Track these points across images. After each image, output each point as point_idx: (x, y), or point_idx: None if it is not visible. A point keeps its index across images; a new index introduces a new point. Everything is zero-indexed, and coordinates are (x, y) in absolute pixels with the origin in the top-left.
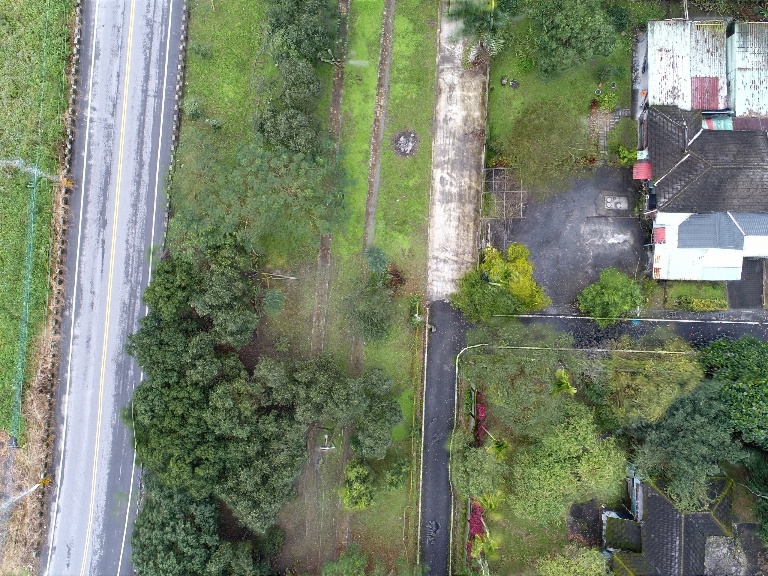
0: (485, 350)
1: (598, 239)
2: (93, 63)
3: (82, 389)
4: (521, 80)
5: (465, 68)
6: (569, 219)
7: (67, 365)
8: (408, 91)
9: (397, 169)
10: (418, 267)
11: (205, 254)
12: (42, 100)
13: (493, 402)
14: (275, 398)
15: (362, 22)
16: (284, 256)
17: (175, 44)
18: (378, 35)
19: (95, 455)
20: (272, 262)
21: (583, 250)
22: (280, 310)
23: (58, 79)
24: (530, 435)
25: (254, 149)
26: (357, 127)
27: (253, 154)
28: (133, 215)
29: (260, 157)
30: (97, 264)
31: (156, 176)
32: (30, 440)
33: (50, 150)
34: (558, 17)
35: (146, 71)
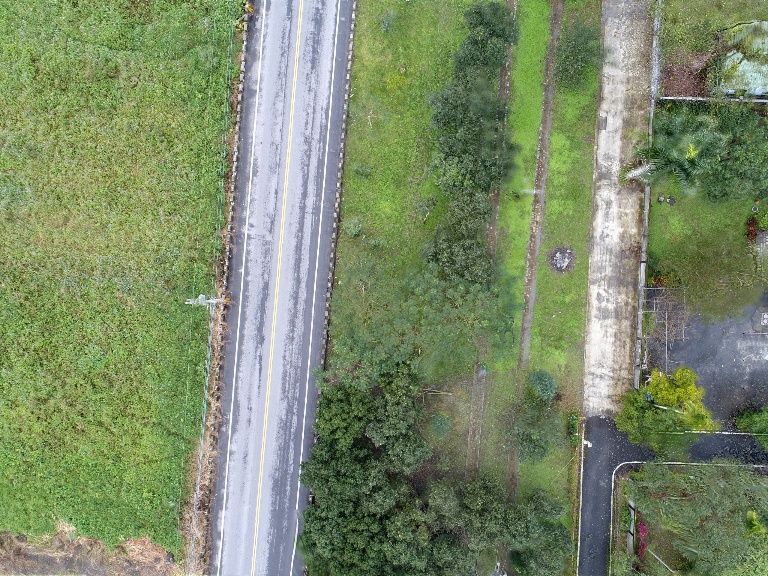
0: (644, 468)
1: (754, 355)
2: (251, 180)
3: (239, 505)
4: (678, 197)
5: (622, 185)
6: (725, 335)
7: (224, 481)
8: (564, 207)
9: (553, 285)
10: (574, 383)
11: (379, 383)
12: (200, 217)
13: (656, 523)
14: (447, 525)
15: (519, 139)
16: (440, 371)
17: (333, 161)
18: (534, 151)
19: (252, 571)
20: (427, 377)
21: (739, 366)
22: (436, 425)
23: (216, 195)
24: (712, 570)
25: (429, 279)
26: (513, 243)
27: (427, 283)
28: (290, 331)
29: (435, 287)
30: (254, 380)
31: (313, 293)
32: (187, 556)
33: (207, 266)
34: (738, 151)
35: (304, 188)
